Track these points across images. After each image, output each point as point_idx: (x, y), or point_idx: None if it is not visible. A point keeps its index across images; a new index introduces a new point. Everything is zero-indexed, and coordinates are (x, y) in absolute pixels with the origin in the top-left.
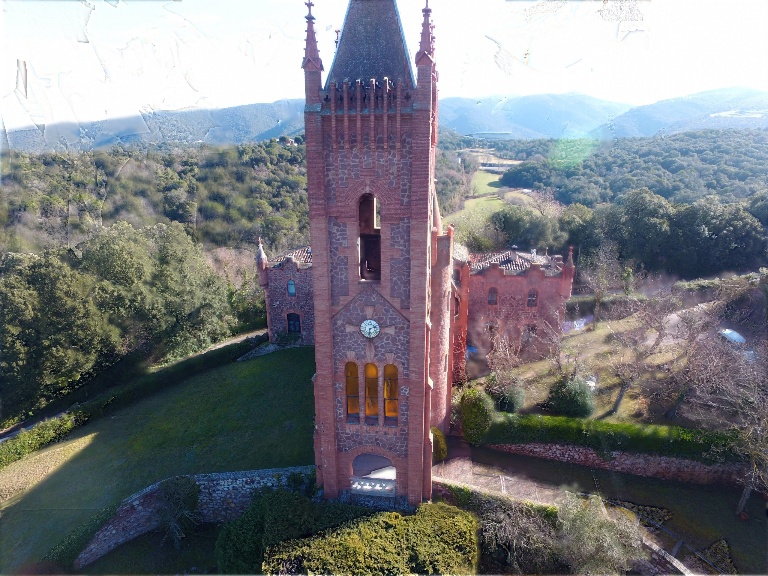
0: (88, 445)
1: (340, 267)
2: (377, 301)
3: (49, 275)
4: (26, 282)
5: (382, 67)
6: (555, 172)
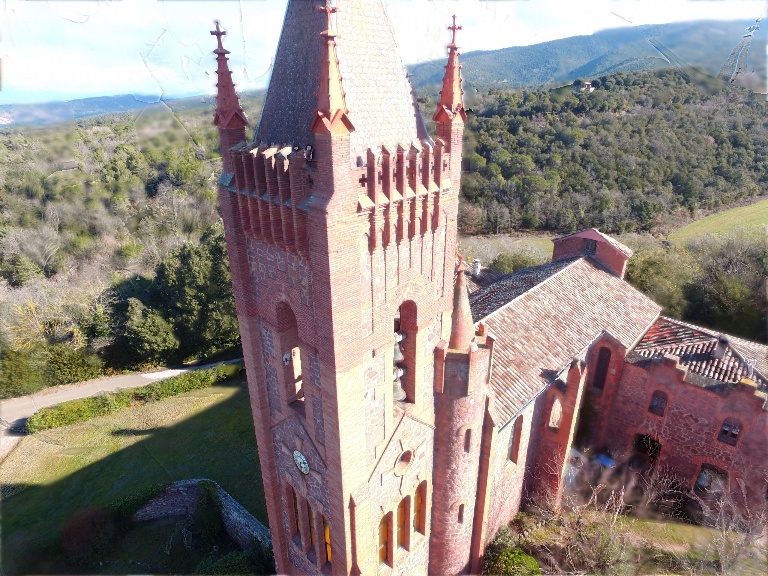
0: (210, 404)
1: (273, 377)
2: (305, 436)
3: (223, 249)
4: (209, 252)
5: (305, 123)
6: None
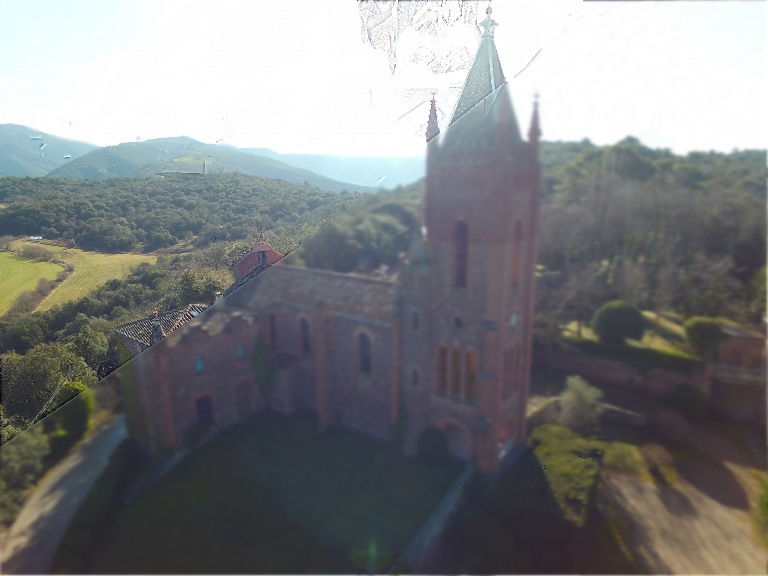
0: None
1: None
2: None
3: None
4: None
5: None
6: (218, 211)
